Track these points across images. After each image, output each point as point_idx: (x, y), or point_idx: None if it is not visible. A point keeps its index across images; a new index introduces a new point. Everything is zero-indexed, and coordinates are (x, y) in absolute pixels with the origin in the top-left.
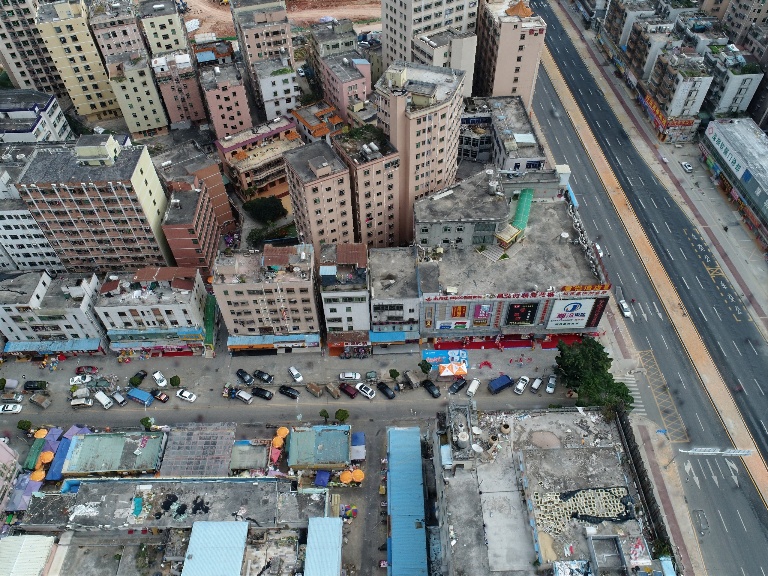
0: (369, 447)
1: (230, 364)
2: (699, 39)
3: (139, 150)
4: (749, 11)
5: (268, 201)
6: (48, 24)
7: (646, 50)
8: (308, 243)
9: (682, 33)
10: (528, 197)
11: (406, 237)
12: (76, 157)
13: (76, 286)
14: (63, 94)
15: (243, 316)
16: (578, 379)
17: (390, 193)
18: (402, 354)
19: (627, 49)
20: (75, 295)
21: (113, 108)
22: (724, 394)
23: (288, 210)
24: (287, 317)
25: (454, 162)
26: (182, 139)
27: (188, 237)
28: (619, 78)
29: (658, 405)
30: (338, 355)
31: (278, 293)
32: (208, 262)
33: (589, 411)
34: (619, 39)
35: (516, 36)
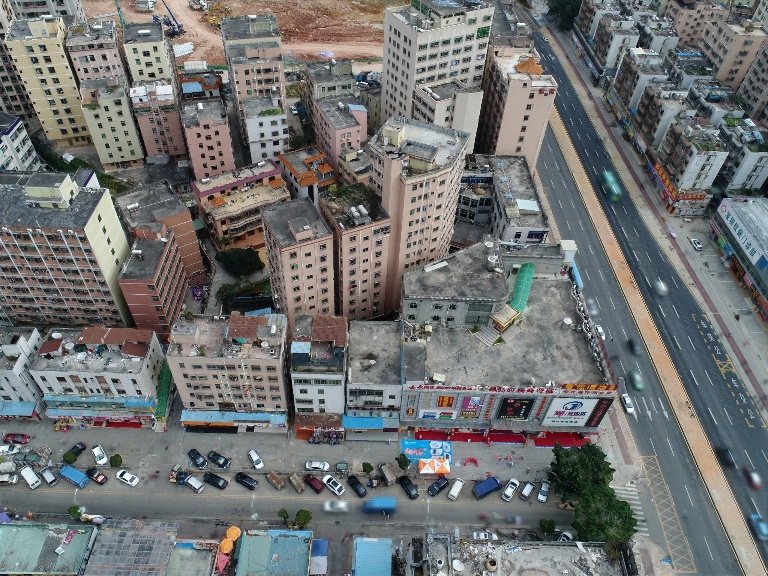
0: (332, 557)
1: (182, 441)
2: (714, 110)
3: (100, 193)
4: (767, 86)
5: (243, 254)
6: (19, 42)
7: (658, 116)
8: (282, 308)
9: (696, 101)
10: (529, 273)
11: (392, 305)
12: (27, 196)
13: (11, 344)
14: (34, 114)
15: (201, 390)
16: (575, 492)
17: (378, 260)
18: (378, 442)
19: (637, 113)
20: (9, 353)
21: (86, 135)
22: (736, 515)
23: (265, 263)
24: (251, 394)
25: (450, 227)
26: (157, 175)
27: (147, 293)
28: (627, 141)
29: (662, 524)
30: (306, 438)
31: (242, 369)
32: (169, 320)
33: (590, 547)
34: (629, 101)
35: (525, 94)
